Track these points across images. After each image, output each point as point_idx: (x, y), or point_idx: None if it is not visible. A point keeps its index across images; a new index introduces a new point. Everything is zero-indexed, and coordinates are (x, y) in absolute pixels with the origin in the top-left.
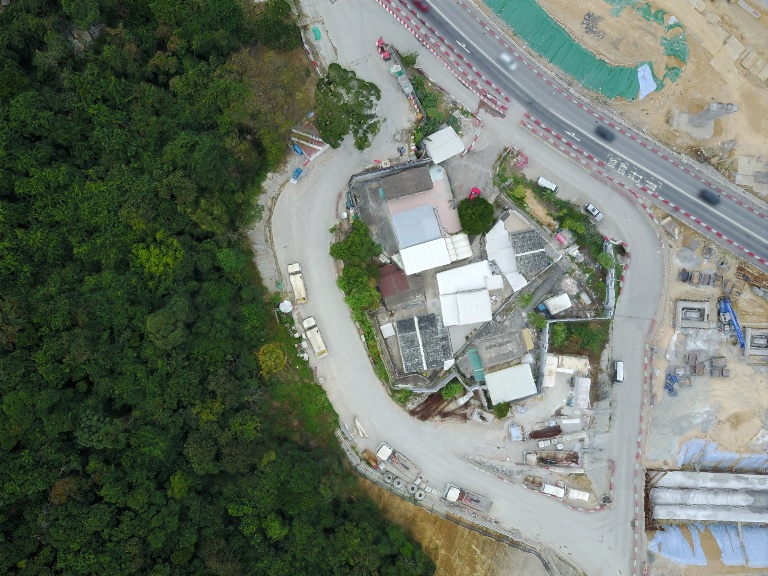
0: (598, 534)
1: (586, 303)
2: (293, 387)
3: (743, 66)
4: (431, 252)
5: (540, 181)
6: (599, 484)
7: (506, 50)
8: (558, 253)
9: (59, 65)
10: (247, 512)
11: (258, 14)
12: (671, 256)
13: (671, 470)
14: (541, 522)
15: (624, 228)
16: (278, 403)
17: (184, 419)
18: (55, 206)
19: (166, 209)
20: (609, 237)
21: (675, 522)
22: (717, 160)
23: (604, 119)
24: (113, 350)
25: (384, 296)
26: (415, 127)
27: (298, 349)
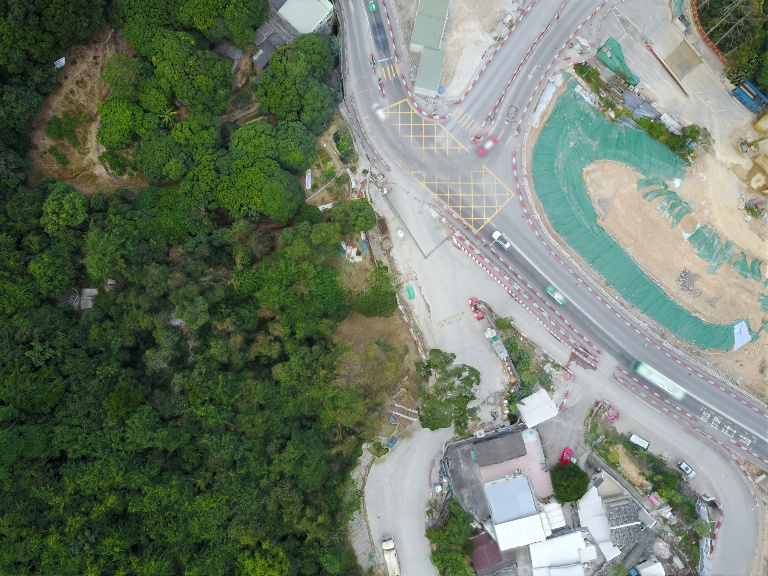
0: None
1: (679, 567)
2: None
3: None
4: (526, 528)
5: (632, 439)
6: None
7: (598, 301)
8: (652, 519)
9: (168, 365)
10: None
11: (358, 293)
12: (765, 514)
13: None
14: None
15: (717, 484)
16: None
17: None
18: (166, 524)
19: (272, 519)
20: (701, 493)
21: None
22: None
23: (698, 373)
24: None
25: (476, 568)
26: (508, 389)
27: None
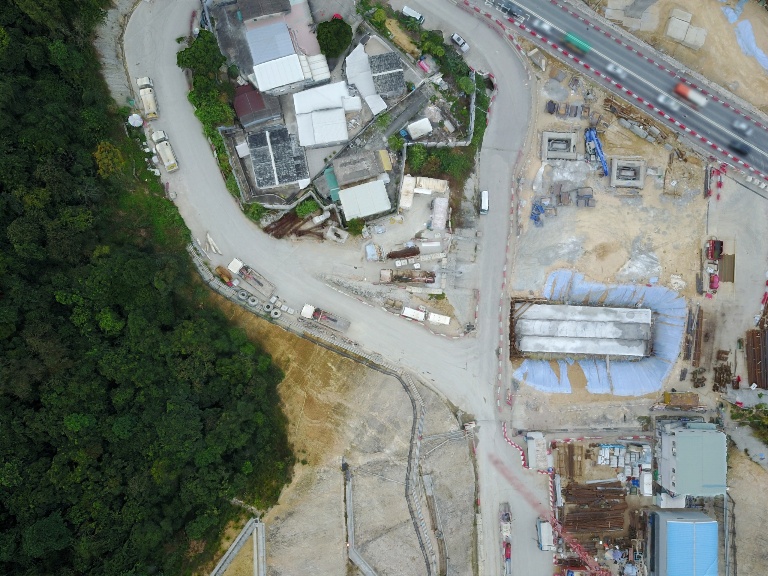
0: (462, 361)
1: (450, 131)
2: (142, 199)
3: None
4: (284, 68)
5: (404, 10)
6: (463, 311)
7: None
8: (420, 78)
9: None
10: (77, 301)
11: None
12: (539, 88)
13: (540, 303)
14: (403, 347)
15: (491, 60)
16: (124, 212)
17: (7, 202)
18: None
19: None
20: (477, 69)
21: (545, 357)
22: None
23: None
24: None
25: (239, 115)
26: None
27: (149, 164)
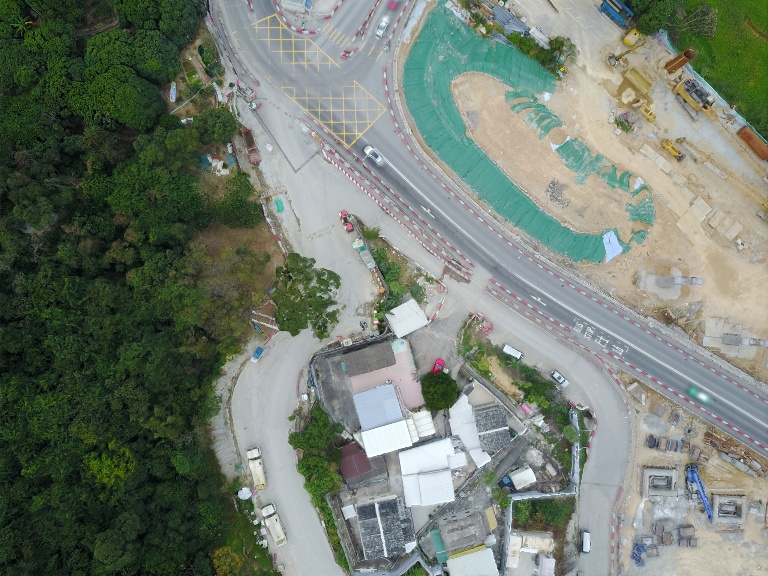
0: None
1: (552, 474)
2: None
3: (710, 225)
4: (392, 435)
5: (505, 349)
6: None
7: (471, 215)
8: (523, 426)
9: (12, 268)
10: None
11: (217, 199)
12: (638, 422)
13: None
14: None
15: (591, 393)
16: None
17: None
18: (3, 424)
19: (118, 419)
20: (575, 402)
21: None
22: (684, 321)
23: (570, 284)
24: (60, 575)
25: (345, 477)
26: (378, 300)
27: (257, 536)
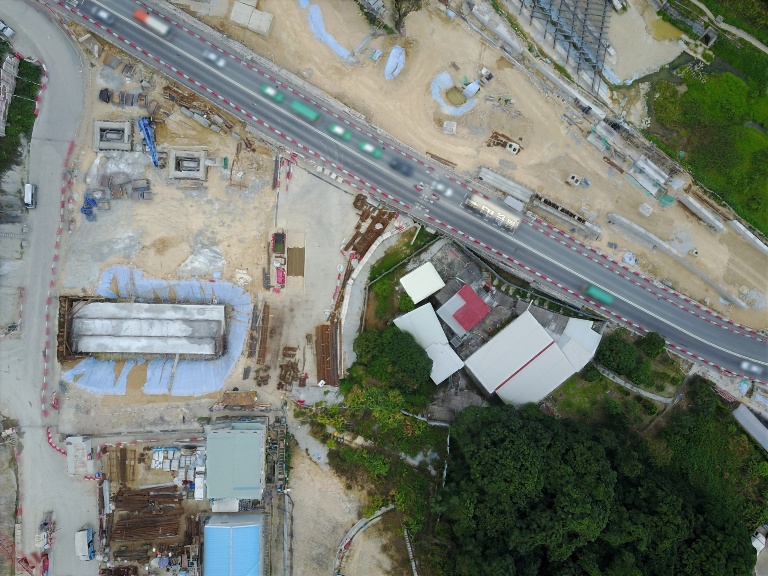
0: (4, 364)
1: None
2: None
3: None
4: None
5: None
6: (2, 311)
7: None
8: None
9: None
10: None
11: None
12: (93, 76)
13: (103, 301)
14: None
15: (42, 46)
16: None
17: None
18: None
19: None
20: (26, 56)
21: (115, 357)
22: None
23: None
24: None
25: None
26: None
27: None
